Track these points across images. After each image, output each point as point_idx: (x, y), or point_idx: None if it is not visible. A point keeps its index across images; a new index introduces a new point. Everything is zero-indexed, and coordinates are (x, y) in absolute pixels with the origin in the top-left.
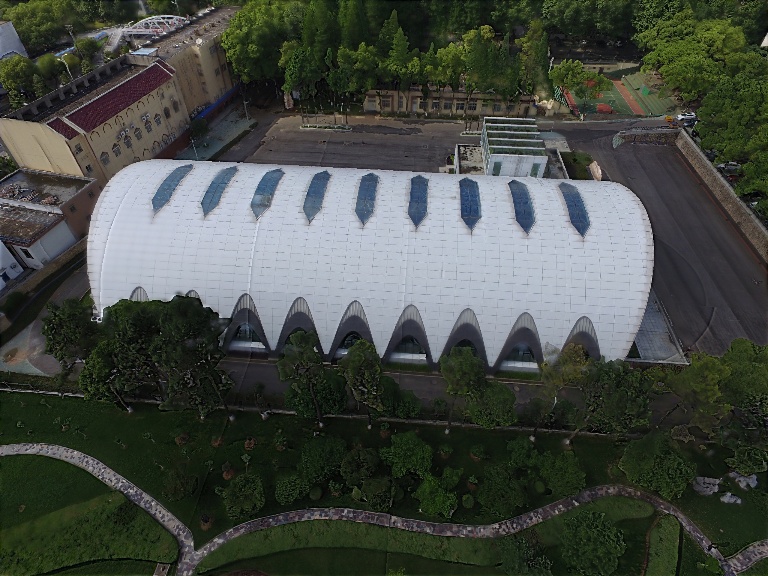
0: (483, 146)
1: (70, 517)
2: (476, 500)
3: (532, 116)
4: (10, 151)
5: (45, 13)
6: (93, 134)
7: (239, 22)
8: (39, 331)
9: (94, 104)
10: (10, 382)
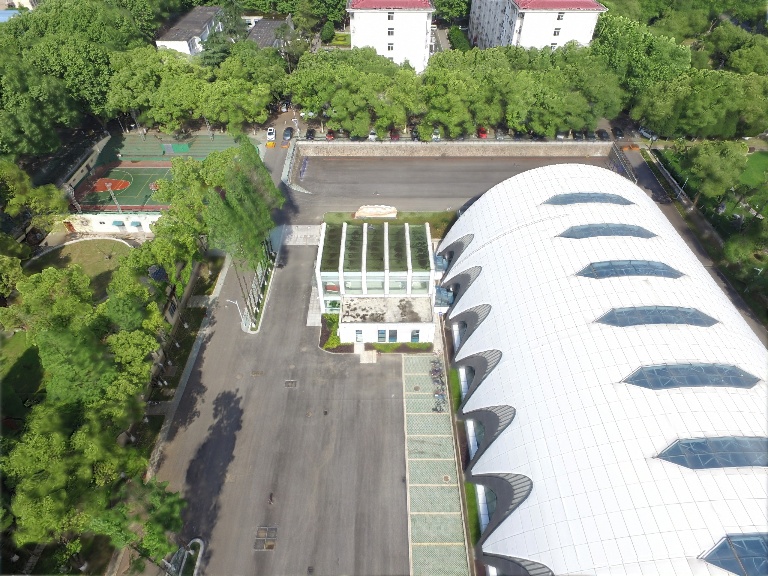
0: (346, 293)
1: None
2: None
3: None
4: None
5: None
6: None
7: None
8: None
9: None
10: None
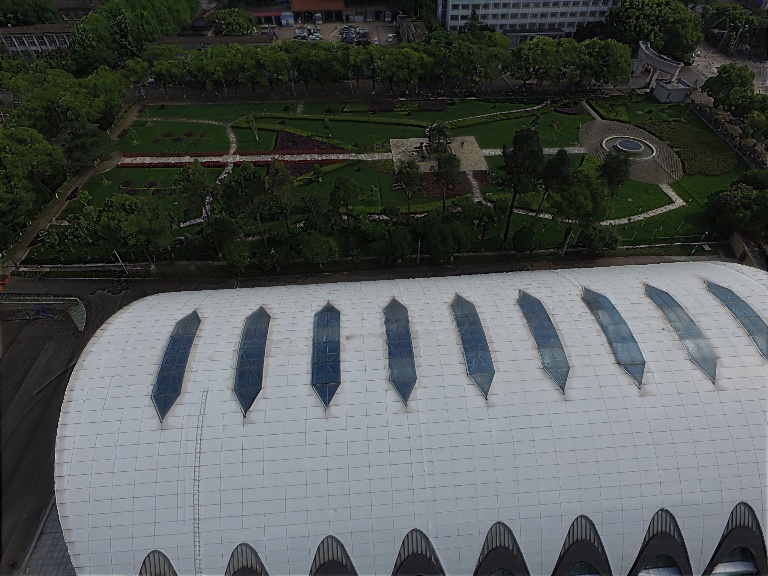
0: None
1: None
2: None
3: None
4: None
5: None
6: None
7: None
8: None
9: None
10: (683, 250)
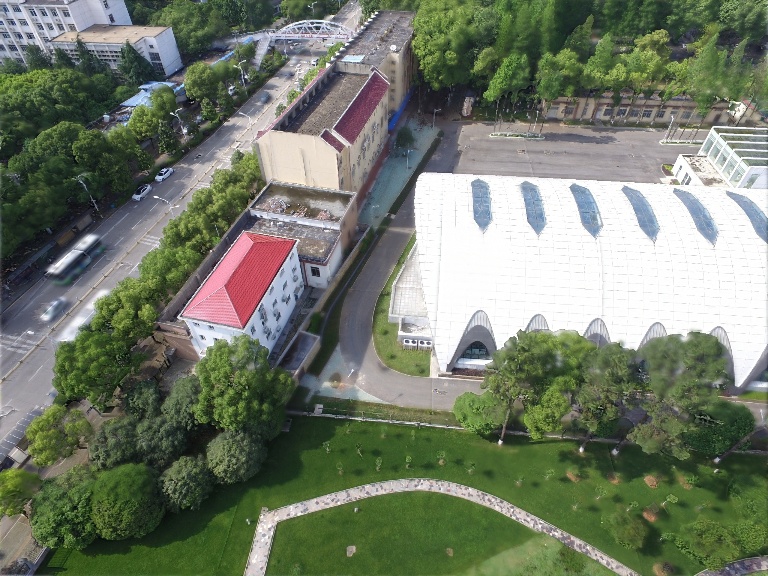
0: (710, 156)
1: (515, 563)
2: None
3: (723, 124)
4: (263, 163)
5: (199, 18)
6: (352, 146)
7: (428, 28)
8: (350, 354)
9: (347, 115)
10: (354, 410)
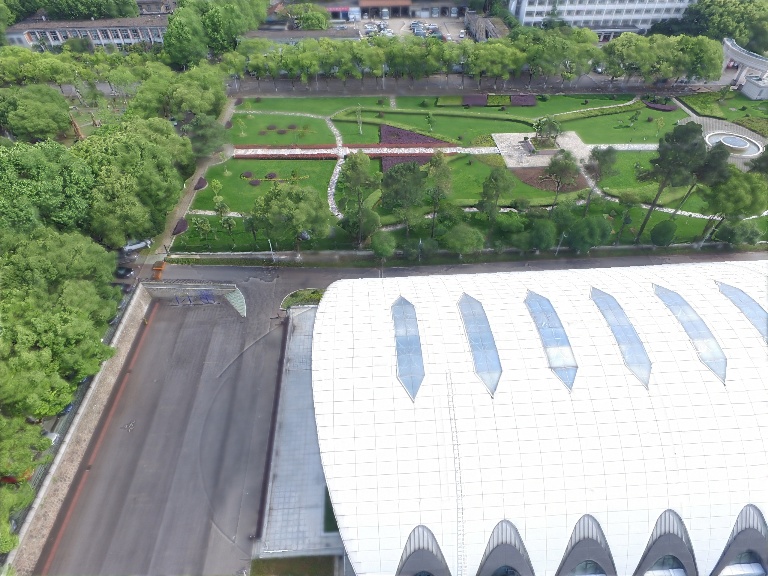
0: None
1: (672, 195)
2: (464, 213)
3: None
4: None
5: None
6: None
7: None
8: None
9: None
10: None
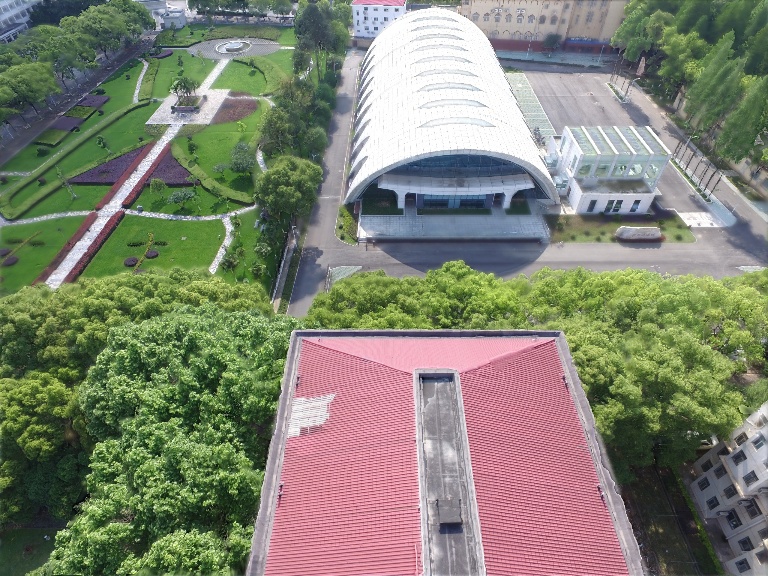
0: None
1: (282, 75)
2: None
3: None
4: None
5: None
6: None
7: None
8: None
9: None
10: None
